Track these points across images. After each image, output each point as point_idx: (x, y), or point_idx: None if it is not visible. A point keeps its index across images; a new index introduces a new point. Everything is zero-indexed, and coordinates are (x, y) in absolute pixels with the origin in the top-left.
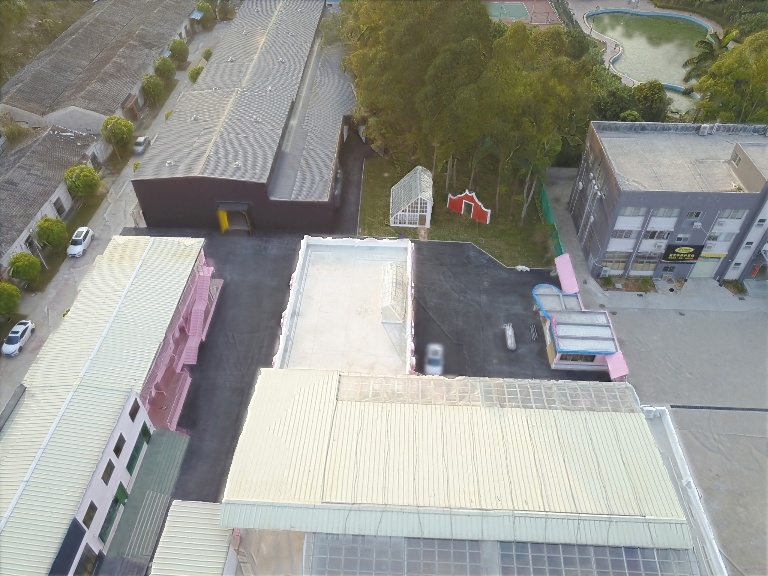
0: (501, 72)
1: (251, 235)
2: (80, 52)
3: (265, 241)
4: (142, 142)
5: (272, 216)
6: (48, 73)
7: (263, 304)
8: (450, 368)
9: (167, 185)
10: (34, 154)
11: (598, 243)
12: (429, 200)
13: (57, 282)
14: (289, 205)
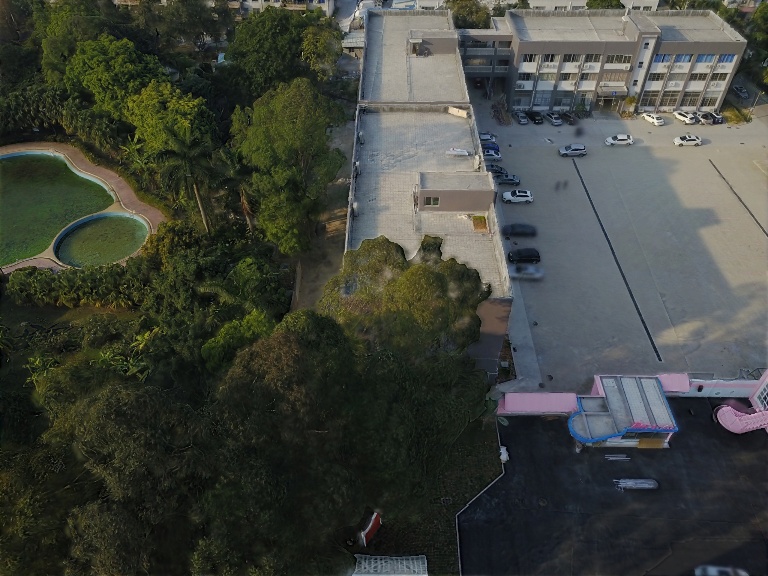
0: (443, 340)
1: None
2: None
3: None
4: None
5: None
6: None
7: None
8: (719, 562)
9: None
10: None
11: (488, 359)
12: (424, 561)
13: None
14: None
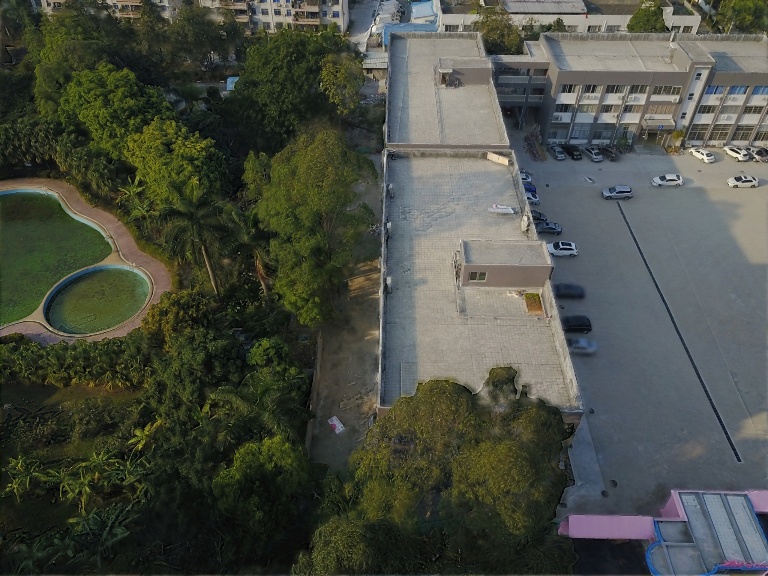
0: None
1: None
2: None
3: None
4: None
5: None
6: None
7: None
8: None
9: None
10: None
11: None
12: None
13: None
14: None
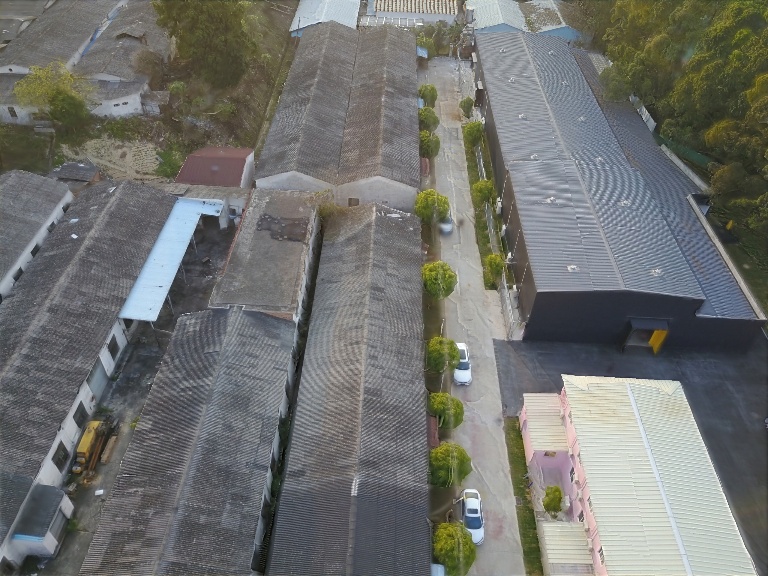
0: None
1: (656, 354)
2: (331, 99)
3: (677, 363)
4: (449, 218)
5: (686, 333)
6: (316, 128)
7: (735, 460)
8: None
9: (580, 298)
10: (378, 245)
11: None
12: None
13: (463, 423)
14: (717, 323)
